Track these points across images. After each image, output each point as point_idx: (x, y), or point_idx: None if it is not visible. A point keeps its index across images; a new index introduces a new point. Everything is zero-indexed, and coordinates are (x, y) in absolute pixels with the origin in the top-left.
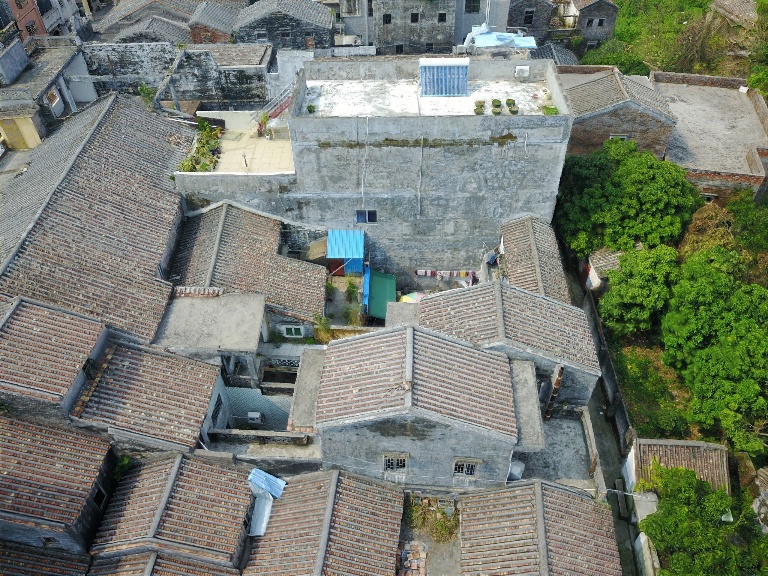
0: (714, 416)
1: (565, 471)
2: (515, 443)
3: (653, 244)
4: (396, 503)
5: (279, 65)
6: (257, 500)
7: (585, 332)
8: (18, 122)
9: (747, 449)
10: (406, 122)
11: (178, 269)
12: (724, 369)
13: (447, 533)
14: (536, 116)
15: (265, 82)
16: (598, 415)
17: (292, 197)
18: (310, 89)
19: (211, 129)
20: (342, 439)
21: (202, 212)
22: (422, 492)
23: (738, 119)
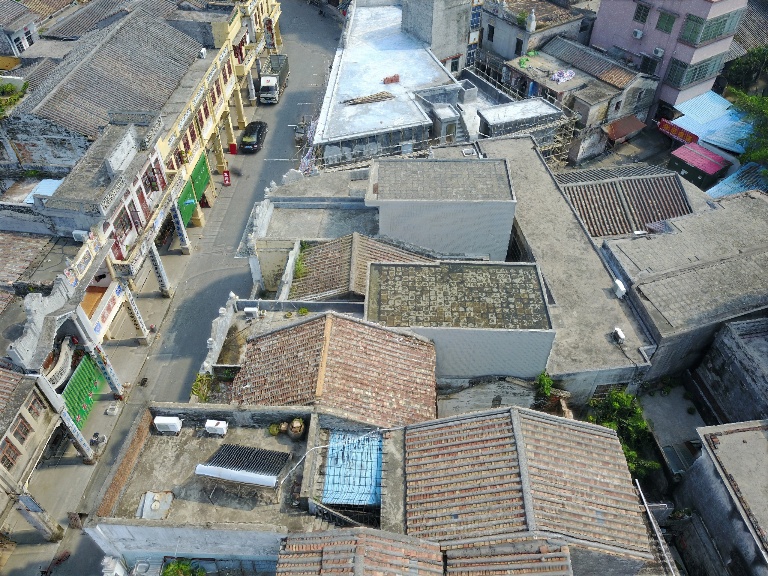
0: None
1: None
2: None
3: None
4: None
5: None
6: None
7: None
8: None
9: None
10: None
11: None
12: None
13: None
14: None
15: None
16: None
17: None
18: None
19: None
20: None
21: None
22: None
23: None
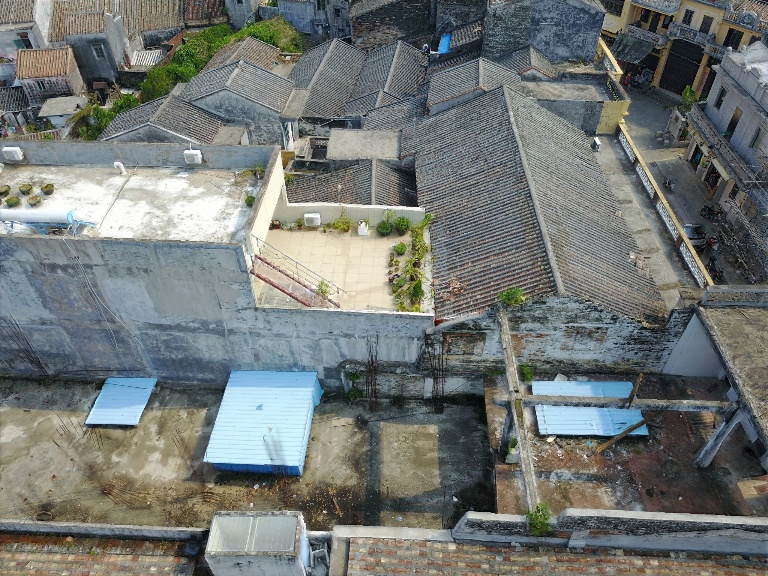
0: None
1: None
2: None
3: None
4: None
5: None
6: None
7: None
8: None
9: None
10: None
11: (410, 197)
12: None
13: None
14: None
15: None
16: None
17: None
18: None
19: None
20: None
21: None
22: None
23: None
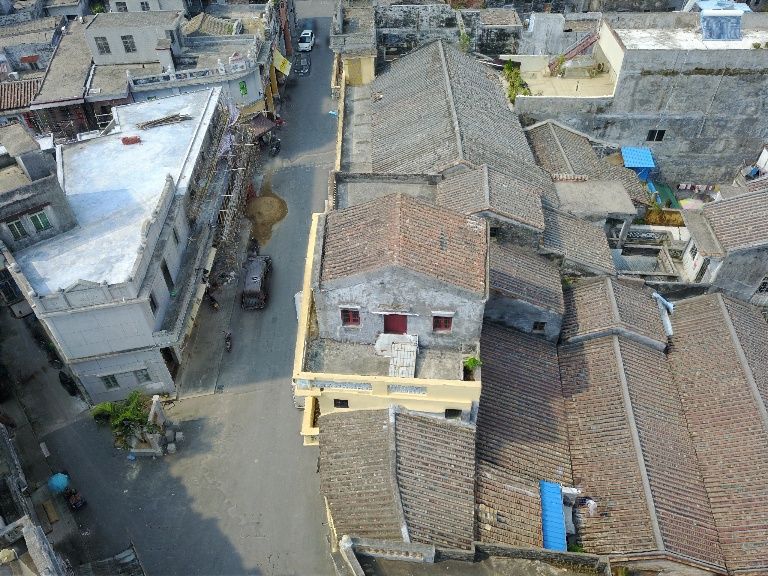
0: None
1: None
2: None
3: None
4: (761, 319)
5: (535, 24)
6: None
7: None
8: (363, 61)
9: None
10: (717, 54)
11: None
12: None
13: None
14: None
15: (519, 39)
16: None
17: (603, 117)
18: None
19: None
20: (740, 263)
21: (527, 130)
22: None
23: None
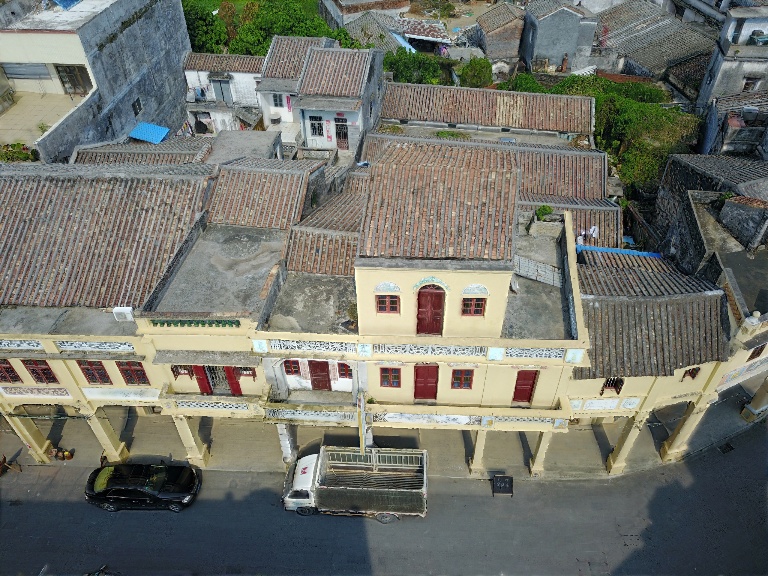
0: None
1: None
2: None
3: (226, 40)
4: None
5: None
6: None
7: None
8: None
9: None
10: (124, 2)
11: None
12: None
13: (399, 129)
14: None
15: None
16: None
17: (104, 115)
18: None
19: None
20: None
21: None
22: None
23: None
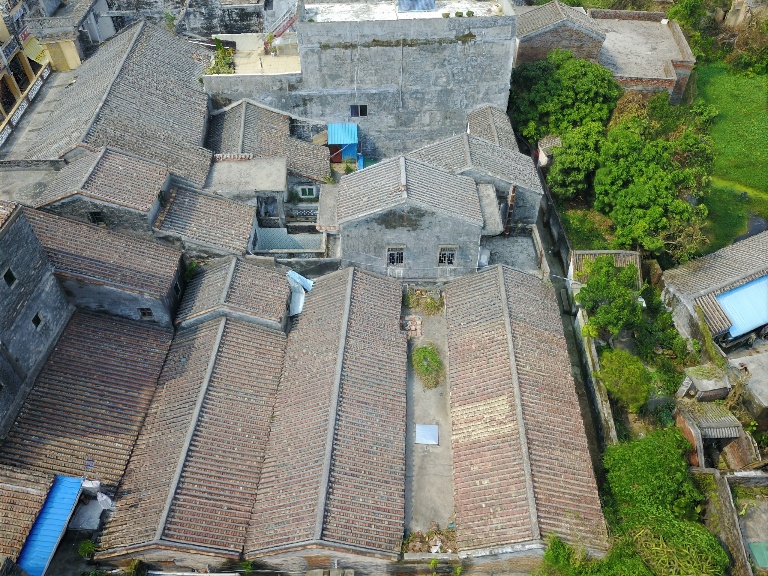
0: (632, 237)
1: (520, 266)
2: (482, 227)
3: None
4: (397, 290)
5: (275, 3)
6: (293, 294)
7: (532, 170)
8: (62, 46)
9: (652, 248)
10: (389, 25)
11: (212, 148)
12: (637, 200)
13: (436, 309)
14: (490, 17)
15: (263, 19)
16: (548, 253)
17: (298, 94)
18: (308, 10)
19: (225, 50)
20: (357, 235)
21: (225, 110)
22: (416, 284)
23: (659, 43)
